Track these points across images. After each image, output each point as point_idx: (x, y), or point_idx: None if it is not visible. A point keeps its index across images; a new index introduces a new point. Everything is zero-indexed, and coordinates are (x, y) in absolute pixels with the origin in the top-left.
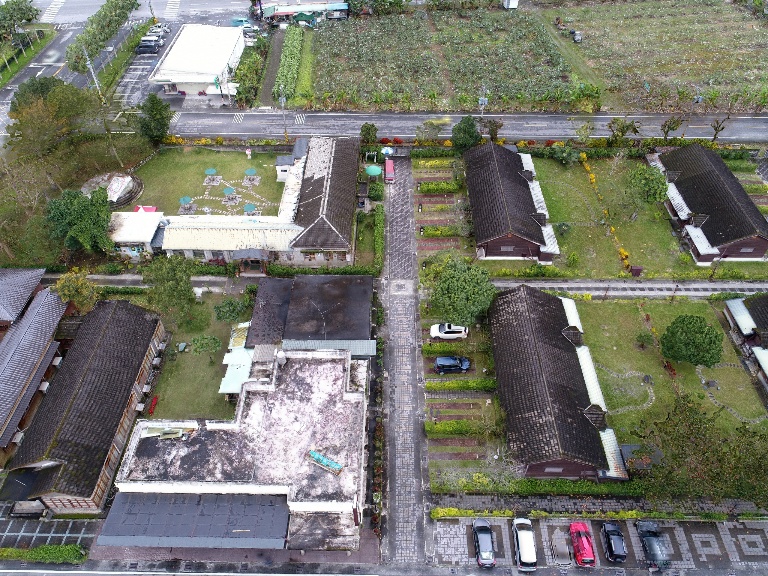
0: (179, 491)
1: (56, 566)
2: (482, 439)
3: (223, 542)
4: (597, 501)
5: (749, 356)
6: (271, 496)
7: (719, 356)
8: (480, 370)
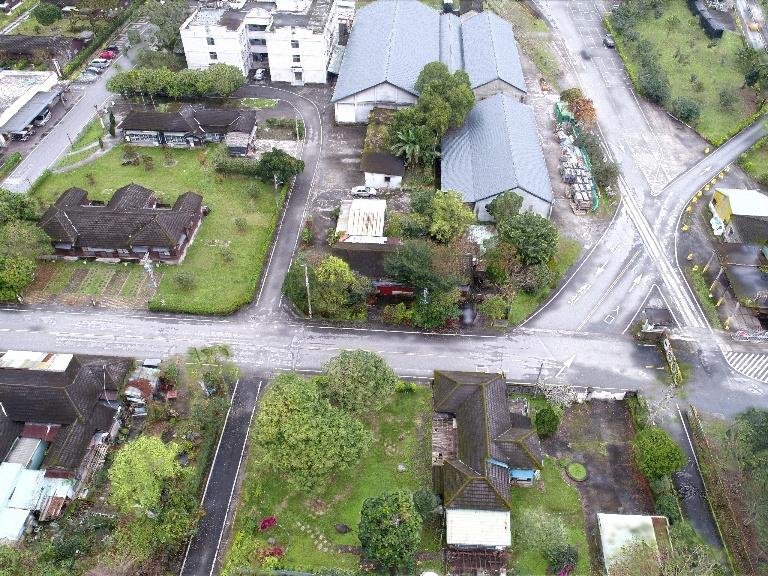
0: (11, 116)
1: (19, 163)
2: (49, 70)
3: (46, 103)
4: (95, 52)
5: (65, 16)
6: (34, 96)
7: (59, 22)
8: (14, 67)
